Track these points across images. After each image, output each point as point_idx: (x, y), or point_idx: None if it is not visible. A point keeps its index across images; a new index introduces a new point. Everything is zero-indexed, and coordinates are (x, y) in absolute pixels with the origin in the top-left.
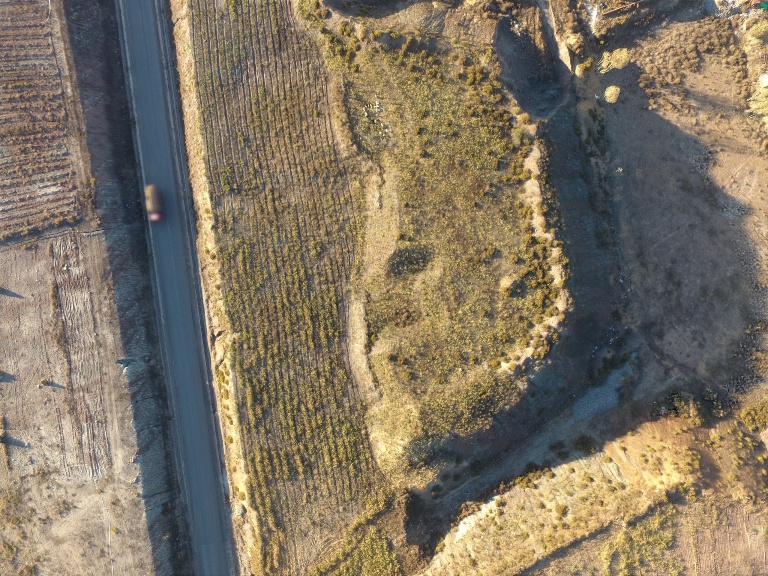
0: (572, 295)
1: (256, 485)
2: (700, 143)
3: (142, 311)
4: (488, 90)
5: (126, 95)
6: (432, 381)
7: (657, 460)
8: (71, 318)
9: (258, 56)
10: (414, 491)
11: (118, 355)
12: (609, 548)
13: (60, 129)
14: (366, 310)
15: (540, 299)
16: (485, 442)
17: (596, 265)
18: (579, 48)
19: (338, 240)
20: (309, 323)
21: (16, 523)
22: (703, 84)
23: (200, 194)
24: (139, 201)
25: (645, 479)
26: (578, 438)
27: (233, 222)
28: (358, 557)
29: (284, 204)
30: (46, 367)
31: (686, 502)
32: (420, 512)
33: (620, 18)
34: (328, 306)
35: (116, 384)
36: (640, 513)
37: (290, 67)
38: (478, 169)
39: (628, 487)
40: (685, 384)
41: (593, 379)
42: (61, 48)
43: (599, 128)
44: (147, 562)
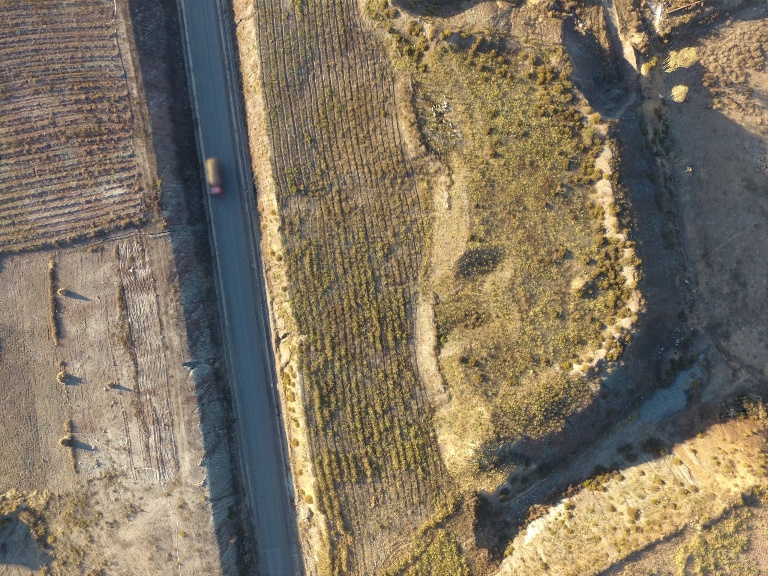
0: (644, 296)
1: (324, 488)
2: (765, 142)
3: (206, 313)
4: (559, 90)
5: (188, 96)
6: (503, 383)
7: (730, 462)
8: (137, 320)
9: (324, 56)
10: (483, 494)
11: (185, 358)
12: (684, 552)
13: (126, 130)
14: (435, 312)
15: (612, 300)
16: (555, 445)
17: (664, 266)
18: (644, 47)
19: (405, 241)
20: (377, 325)
21: (83, 527)
22: (767, 83)
23: (265, 195)
24: (202, 203)
25: (719, 482)
26: (646, 440)
27: (300, 223)
28: (427, 561)
29: (351, 205)
30: (112, 370)
31: (761, 505)
32: (487, 515)
33: (684, 17)
34: (396, 308)
35: (183, 387)
36: (715, 516)
37: (357, 67)
38: (549, 169)
39: (701, 490)
40: (753, 386)
41: (661, 381)
42: (127, 49)
43: (663, 128)
44: (215, 566)
